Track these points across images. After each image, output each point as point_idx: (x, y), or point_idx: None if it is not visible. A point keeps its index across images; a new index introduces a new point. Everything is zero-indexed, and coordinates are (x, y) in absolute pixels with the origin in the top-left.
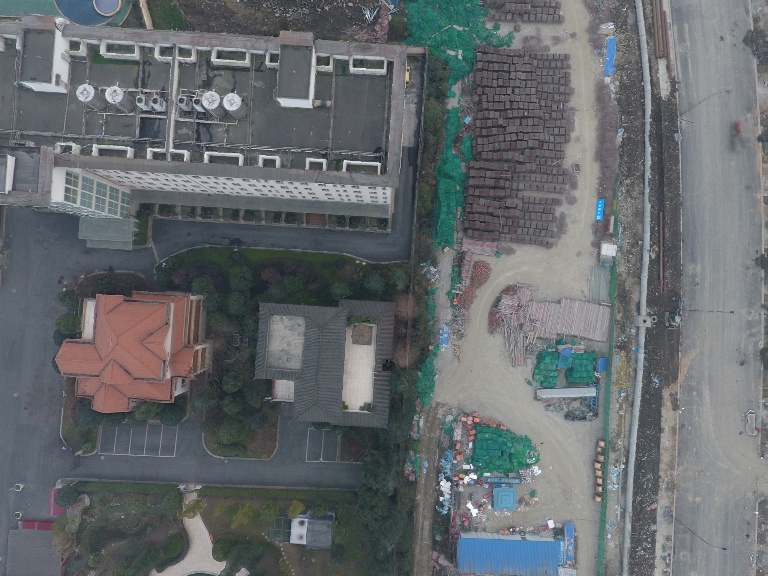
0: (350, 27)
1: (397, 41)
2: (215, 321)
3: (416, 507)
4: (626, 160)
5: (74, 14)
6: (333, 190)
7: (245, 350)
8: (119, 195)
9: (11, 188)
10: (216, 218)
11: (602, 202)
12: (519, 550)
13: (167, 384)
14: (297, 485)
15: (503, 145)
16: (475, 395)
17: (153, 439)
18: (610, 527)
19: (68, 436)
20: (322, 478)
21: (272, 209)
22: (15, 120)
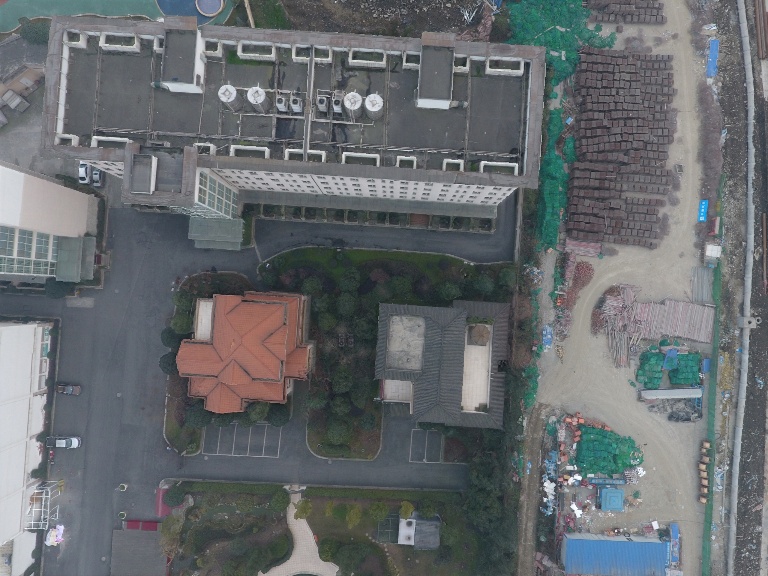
0: (449, 28)
1: None
2: (327, 321)
3: (520, 508)
4: (729, 161)
5: None
6: (453, 191)
7: (350, 351)
8: (231, 195)
9: (154, 188)
10: (322, 219)
11: (706, 203)
12: (627, 551)
13: (281, 384)
14: (401, 486)
15: (608, 146)
16: (578, 396)
17: (257, 439)
18: (714, 528)
19: (172, 436)
20: (426, 479)
21: (380, 210)
22: (151, 120)
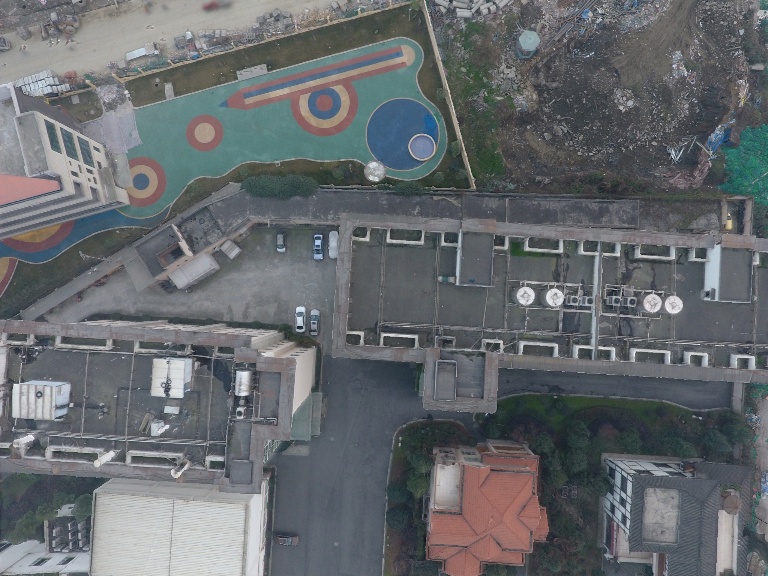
0: (657, 167)
1: (712, 185)
2: (562, 482)
3: None
4: None
5: (387, 158)
6: None
7: (573, 501)
8: None
9: None
10: None
11: None
12: None
13: None
14: None
15: None
16: None
17: None
18: None
19: None
20: None
21: None
22: (437, 315)
